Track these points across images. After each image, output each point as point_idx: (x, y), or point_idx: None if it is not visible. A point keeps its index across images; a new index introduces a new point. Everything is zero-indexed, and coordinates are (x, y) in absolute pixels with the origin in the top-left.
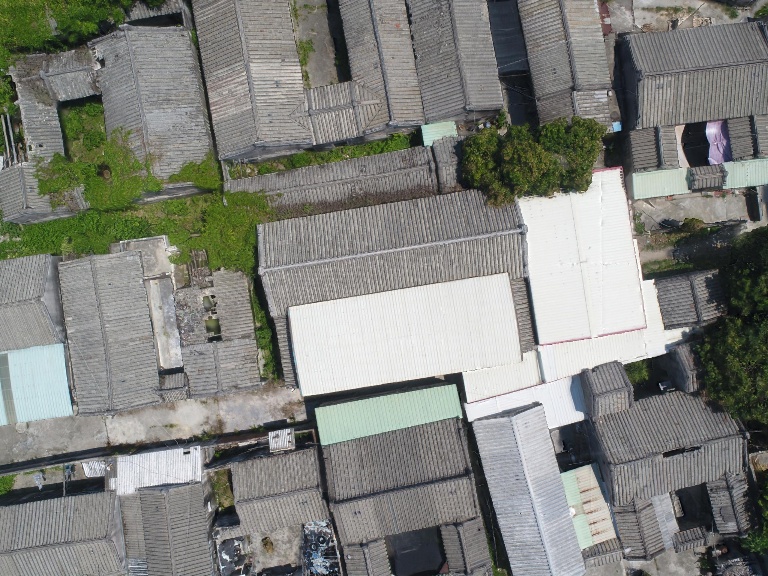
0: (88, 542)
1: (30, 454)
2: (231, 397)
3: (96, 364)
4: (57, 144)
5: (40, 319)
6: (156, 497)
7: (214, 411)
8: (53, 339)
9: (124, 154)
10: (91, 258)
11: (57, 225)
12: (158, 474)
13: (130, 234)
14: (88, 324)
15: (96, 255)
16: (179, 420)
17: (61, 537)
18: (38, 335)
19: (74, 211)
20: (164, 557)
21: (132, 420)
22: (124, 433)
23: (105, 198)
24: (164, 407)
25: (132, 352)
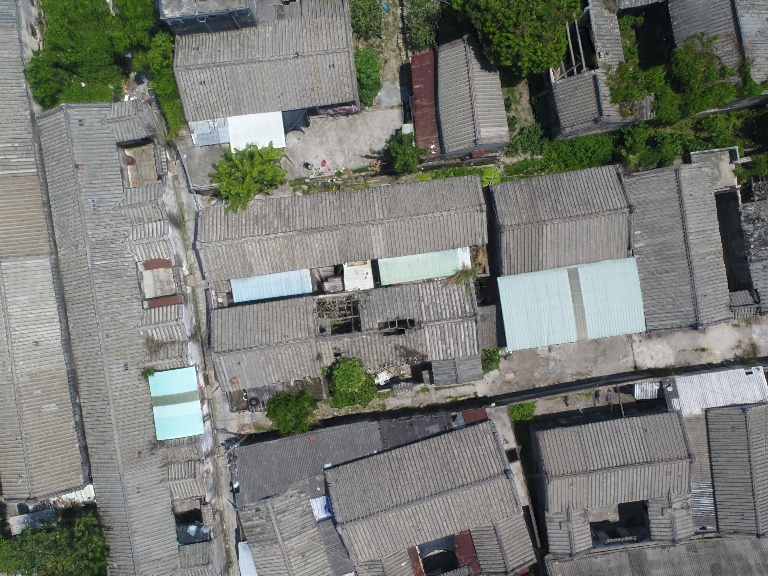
0: (671, 462)
1: (552, 379)
2: (764, 320)
3: (675, 278)
4: (619, 53)
5: (622, 230)
6: (732, 417)
7: (746, 334)
8: (626, 252)
9: (706, 60)
10: (679, 167)
11: (588, 141)
12: (723, 394)
13: (691, 147)
14: (665, 237)
15: (682, 164)
16: (710, 344)
17: (639, 457)
18: (613, 248)
19: (636, 122)
20: (741, 479)
21: (661, 344)
22: (652, 357)
23: (674, 108)
24: (694, 330)
25: (709, 266)
